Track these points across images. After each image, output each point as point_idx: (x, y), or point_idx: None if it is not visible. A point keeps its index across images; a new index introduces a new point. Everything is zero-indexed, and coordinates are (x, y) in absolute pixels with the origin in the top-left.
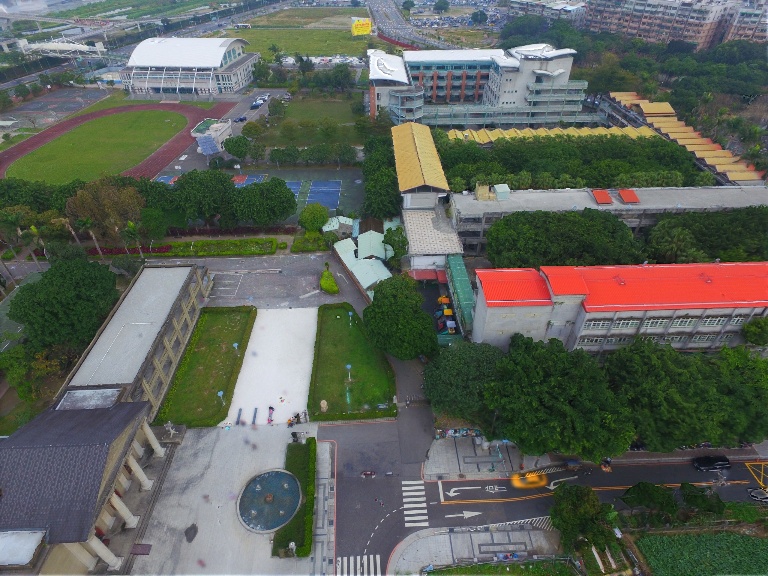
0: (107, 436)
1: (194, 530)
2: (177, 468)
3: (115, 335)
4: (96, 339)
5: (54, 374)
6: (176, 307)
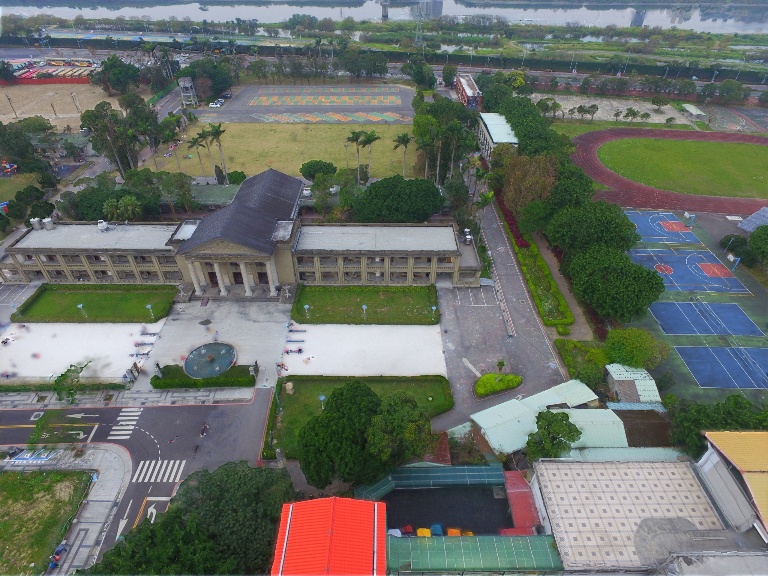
0: (229, 236)
1: (207, 323)
2: (260, 306)
3: (363, 232)
4: (358, 225)
5: (332, 220)
6: (397, 254)
